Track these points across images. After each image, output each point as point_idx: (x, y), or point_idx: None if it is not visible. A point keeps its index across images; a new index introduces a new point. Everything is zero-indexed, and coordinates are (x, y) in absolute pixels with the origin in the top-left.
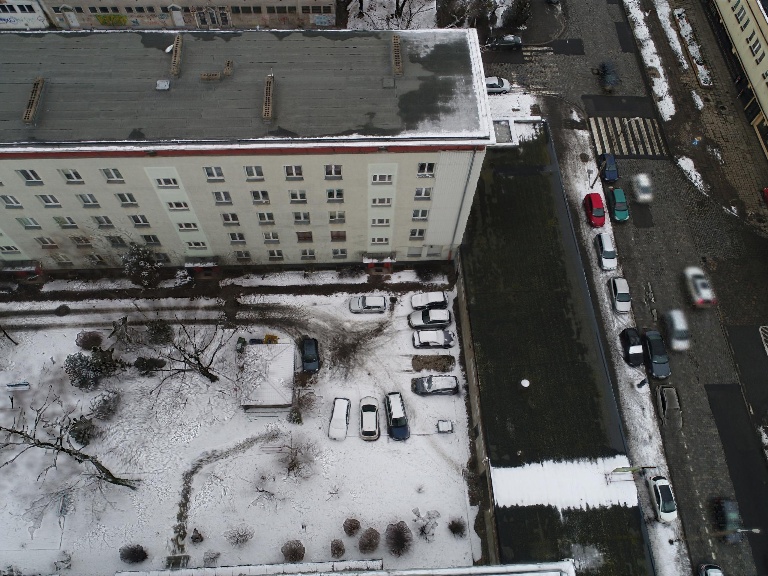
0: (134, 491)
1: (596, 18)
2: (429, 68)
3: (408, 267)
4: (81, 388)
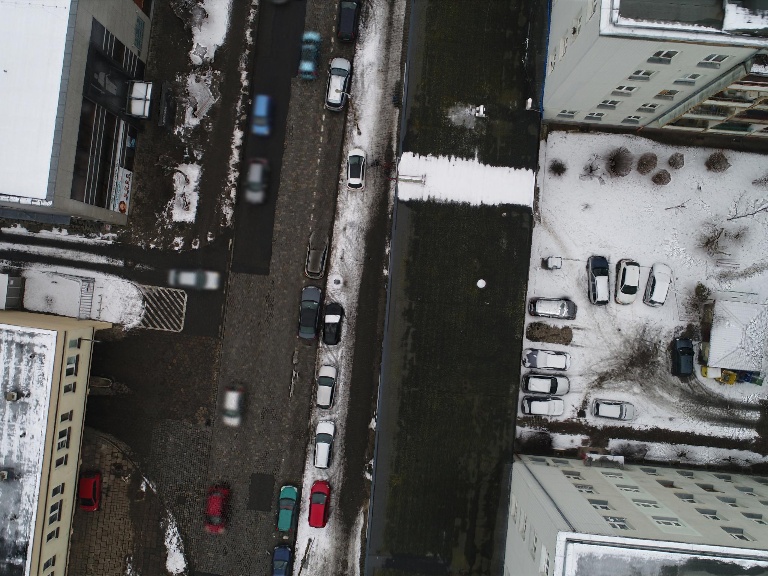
0: None
1: None
2: None
3: (559, 454)
4: None
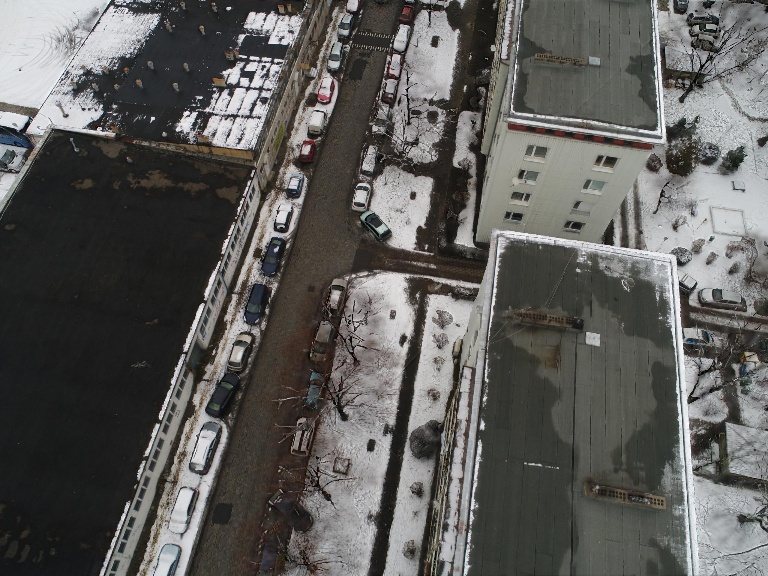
0: (766, 143)
1: None
2: None
3: None
4: (693, 170)
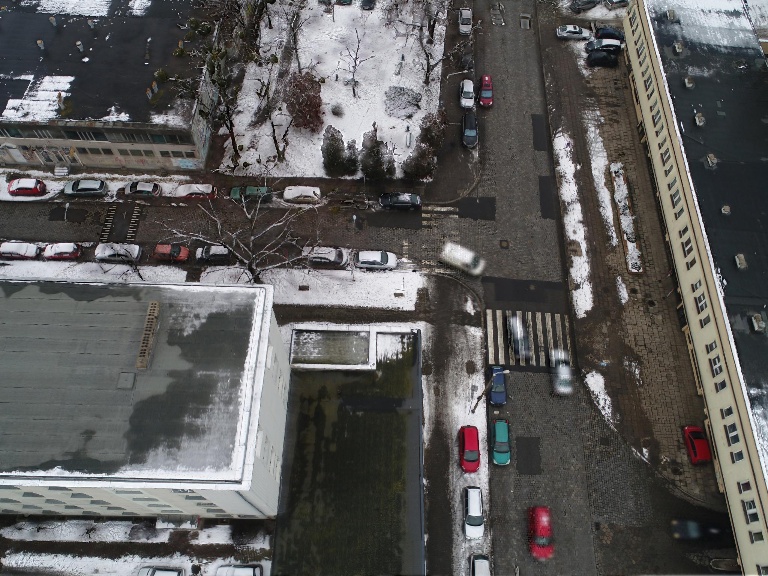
0: None
1: (517, 170)
2: (189, 356)
3: (223, 520)
4: None
